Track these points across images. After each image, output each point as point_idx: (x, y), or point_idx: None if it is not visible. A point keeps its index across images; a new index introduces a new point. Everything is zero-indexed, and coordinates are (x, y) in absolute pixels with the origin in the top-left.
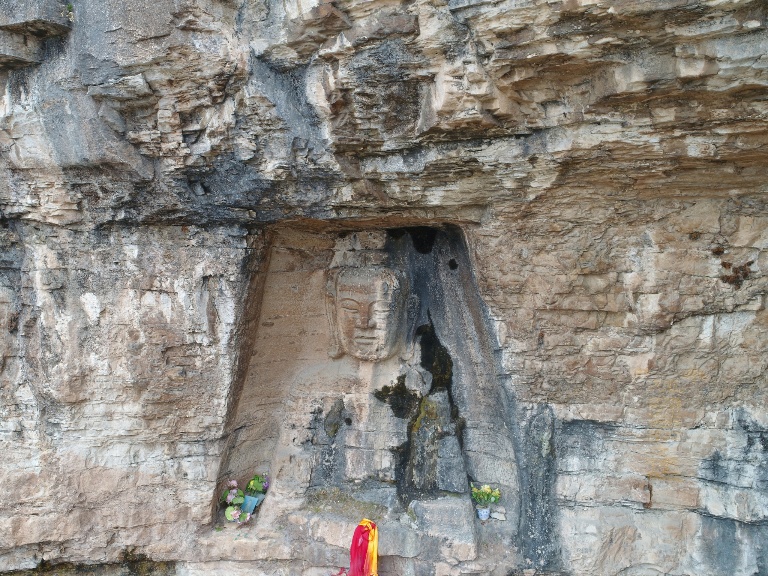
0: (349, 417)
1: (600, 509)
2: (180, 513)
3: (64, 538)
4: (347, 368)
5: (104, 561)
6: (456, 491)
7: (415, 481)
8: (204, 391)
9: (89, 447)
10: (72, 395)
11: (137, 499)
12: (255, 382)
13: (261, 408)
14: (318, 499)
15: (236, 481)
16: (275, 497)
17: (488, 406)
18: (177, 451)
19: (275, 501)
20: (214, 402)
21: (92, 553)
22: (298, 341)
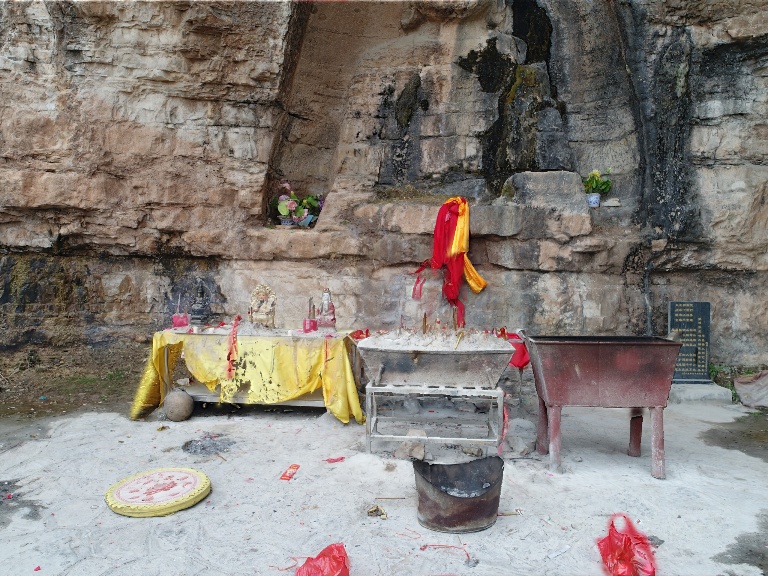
0: (426, 98)
1: (746, 166)
2: (225, 196)
3: (86, 205)
4: (424, 36)
5: (133, 249)
6: (561, 167)
7: (510, 160)
8: (258, 22)
9: (117, 91)
10: (97, 3)
11: (174, 168)
12: (313, 55)
13: (318, 100)
14: (389, 196)
15: (289, 184)
16: (337, 192)
17: (596, 76)
18: (222, 116)
19: (338, 195)
20: (269, 43)
21: (119, 233)
22: (364, 10)
